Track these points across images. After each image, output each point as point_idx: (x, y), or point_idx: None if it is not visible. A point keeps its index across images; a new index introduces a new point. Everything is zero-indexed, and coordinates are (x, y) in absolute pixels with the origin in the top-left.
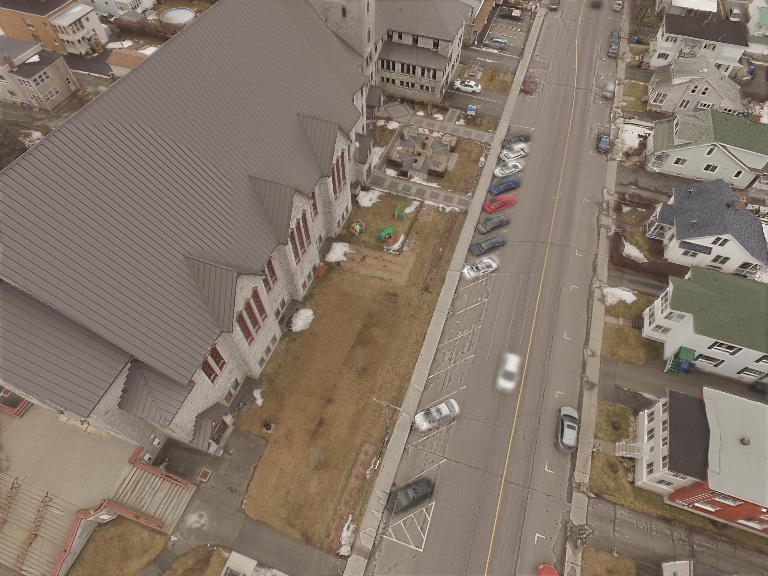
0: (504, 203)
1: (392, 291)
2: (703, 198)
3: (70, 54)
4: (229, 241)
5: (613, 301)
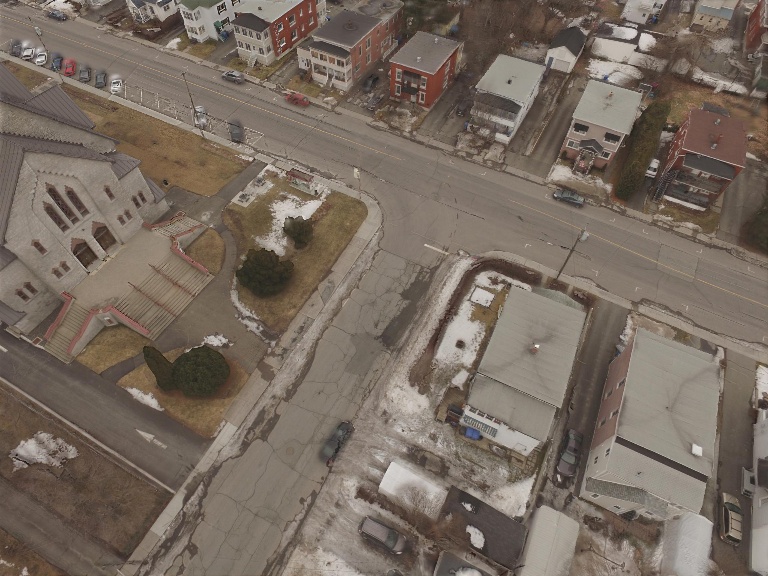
0: (71, 67)
1: (104, 124)
2: None
3: None
4: None
5: (175, 46)
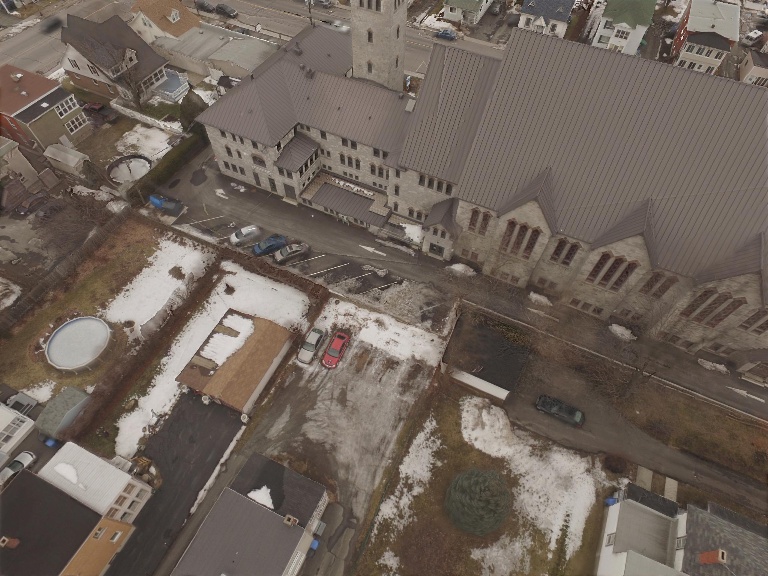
0: None
1: None
2: (539, 1)
3: (135, 521)
4: None
5: None
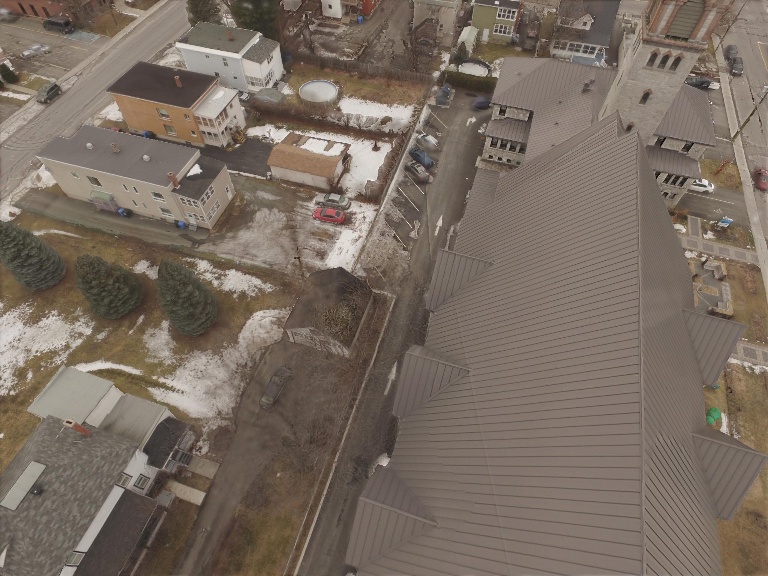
0: None
1: (752, 508)
2: None
3: (207, 146)
4: (708, 555)
5: None
